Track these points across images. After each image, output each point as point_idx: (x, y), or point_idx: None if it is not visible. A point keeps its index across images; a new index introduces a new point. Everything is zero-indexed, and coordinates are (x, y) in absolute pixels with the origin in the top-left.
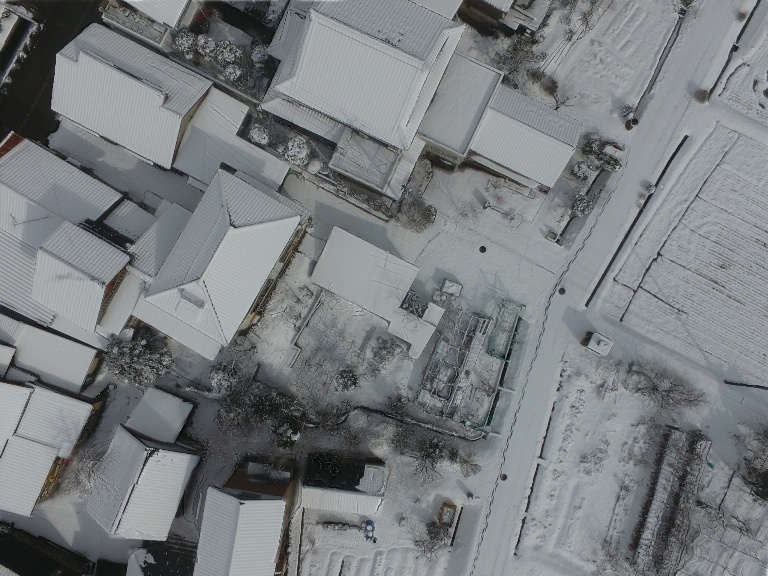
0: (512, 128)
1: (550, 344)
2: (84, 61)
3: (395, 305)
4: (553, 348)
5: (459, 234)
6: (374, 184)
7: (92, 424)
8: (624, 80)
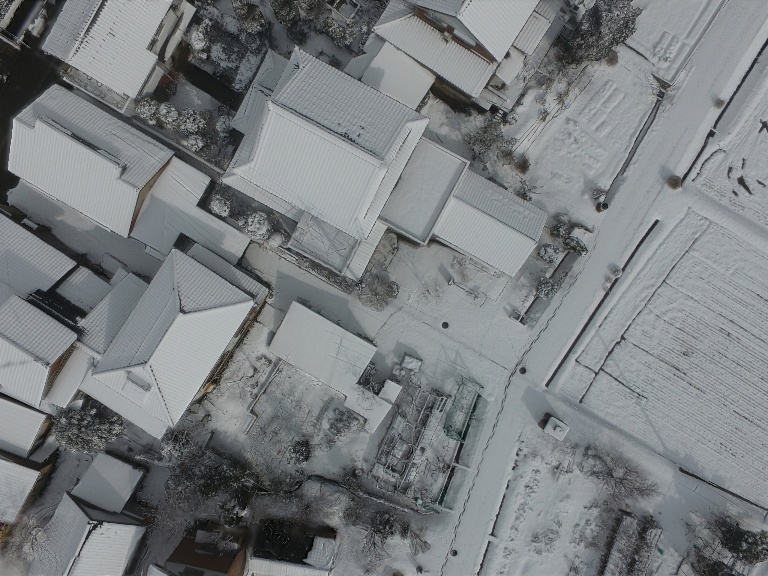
0: (475, 217)
1: (508, 423)
2: (41, 128)
3: (352, 381)
4: (510, 427)
5: (422, 309)
6: (333, 266)
7: (39, 488)
8: (597, 161)
